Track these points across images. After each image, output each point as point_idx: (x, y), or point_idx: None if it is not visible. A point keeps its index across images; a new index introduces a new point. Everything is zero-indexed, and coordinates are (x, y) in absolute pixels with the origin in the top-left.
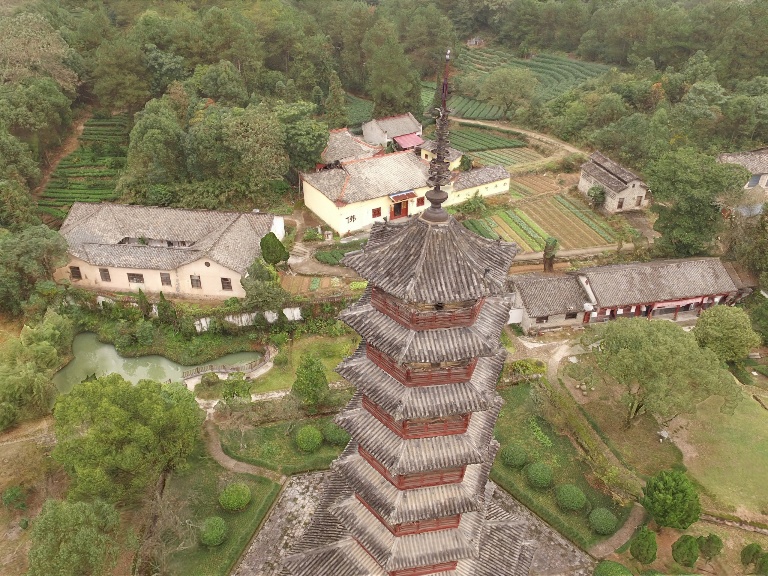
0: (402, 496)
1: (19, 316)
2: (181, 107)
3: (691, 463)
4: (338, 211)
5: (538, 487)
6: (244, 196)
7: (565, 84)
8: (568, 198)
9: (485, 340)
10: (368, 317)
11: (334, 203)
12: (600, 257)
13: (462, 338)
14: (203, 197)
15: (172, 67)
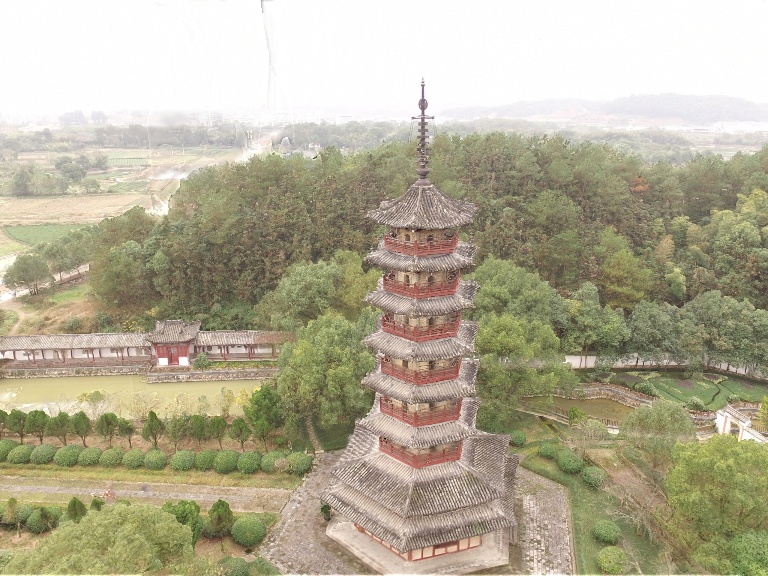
0: None
1: None
2: None
3: None
4: None
5: None
6: None
7: None
8: None
9: None
10: None
11: None
12: None
13: None
14: None
15: None
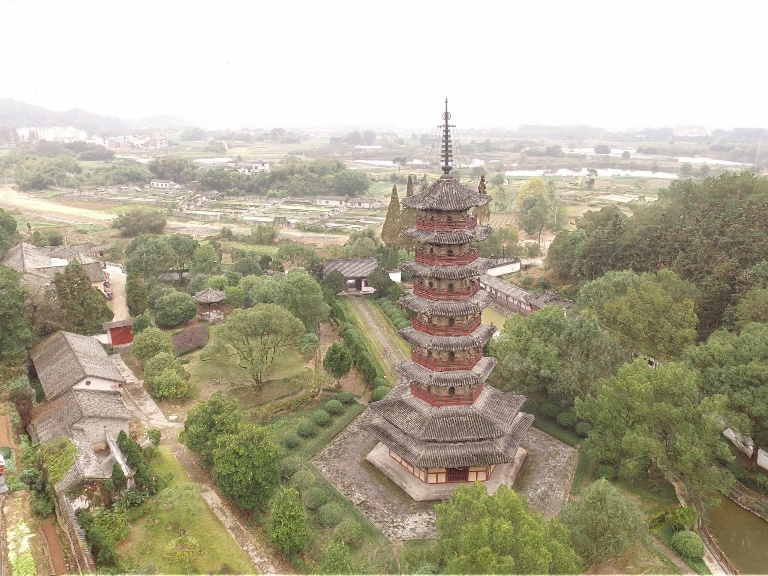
0: None
1: None
2: None
3: (279, 377)
4: None
5: None
6: None
7: None
8: None
9: None
10: None
11: None
12: None
13: None
14: None
15: None
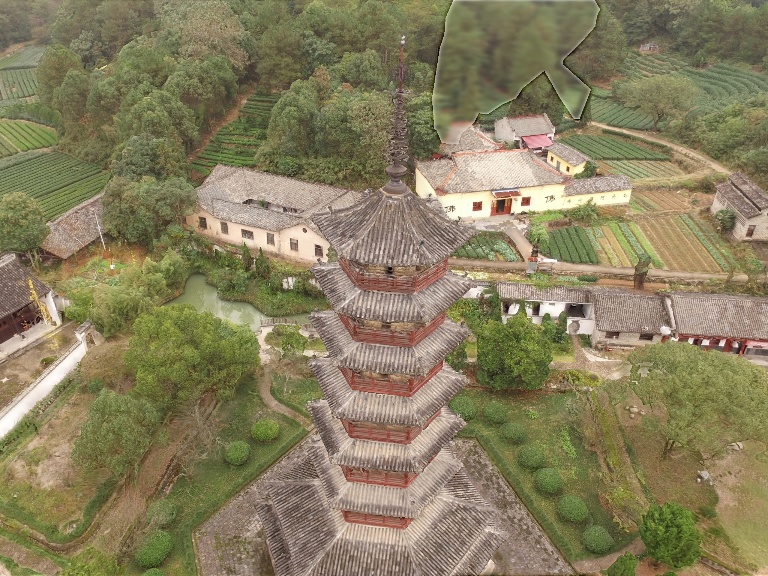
0: (351, 443)
1: (152, 251)
2: (324, 89)
3: (724, 510)
4: None
5: (544, 491)
6: (360, 176)
7: (734, 98)
8: (696, 219)
9: (420, 308)
10: (333, 273)
11: (435, 191)
12: (705, 284)
13: (402, 304)
14: (324, 172)
15: (324, 53)
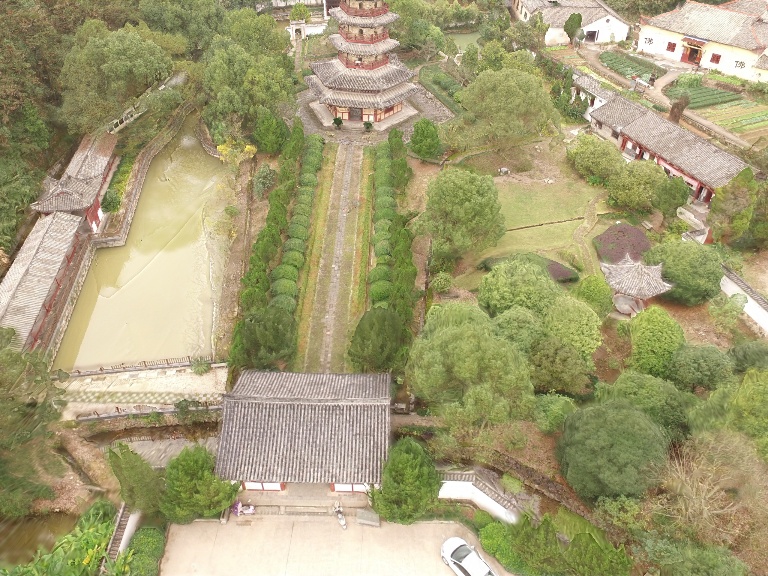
0: (340, 10)
1: None
2: None
3: None
4: (641, 28)
5: None
6: None
7: None
8: None
9: None
10: None
11: None
12: None
13: None
14: (620, 1)
15: None
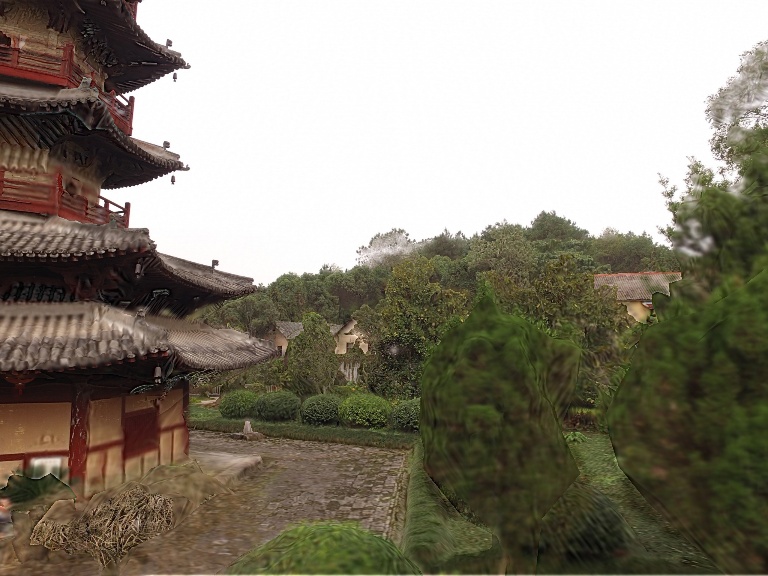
0: None
1: None
2: None
3: None
4: None
5: None
6: None
7: None
8: None
9: None
10: None
11: None
12: None
13: None
14: None
15: None
